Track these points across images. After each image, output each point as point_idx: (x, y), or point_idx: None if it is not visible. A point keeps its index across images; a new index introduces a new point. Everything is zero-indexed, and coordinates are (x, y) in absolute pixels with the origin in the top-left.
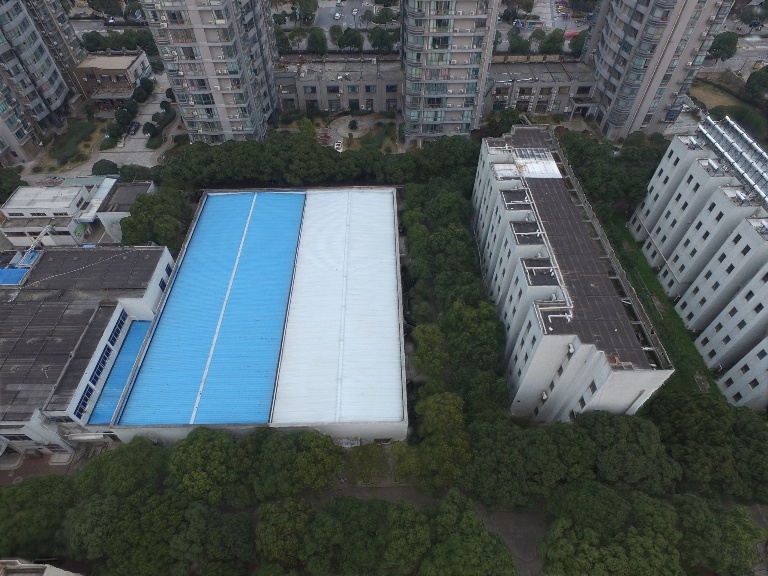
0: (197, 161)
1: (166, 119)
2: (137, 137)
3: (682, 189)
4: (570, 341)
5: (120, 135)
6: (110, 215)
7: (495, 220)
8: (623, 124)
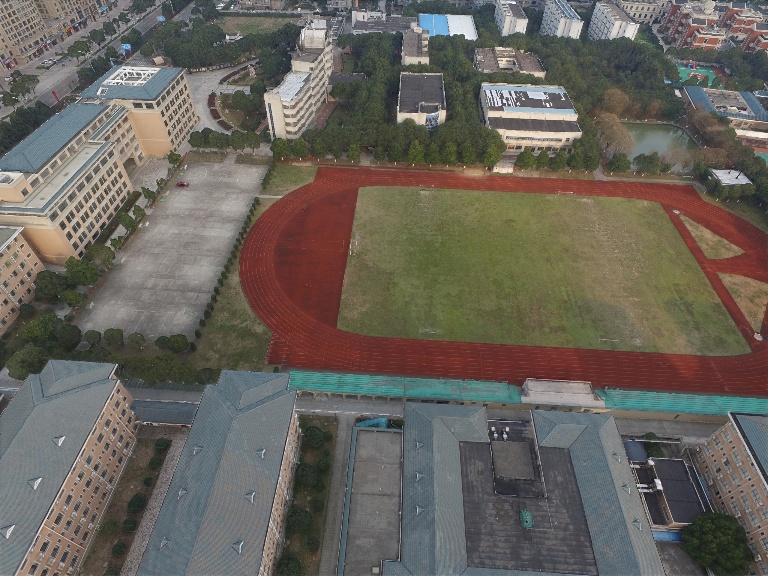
0: (417, 5)
1: (390, 5)
2: (381, 9)
3: (547, 12)
4: (511, 18)
5: (377, 8)
6: None
7: (499, 12)
8: None
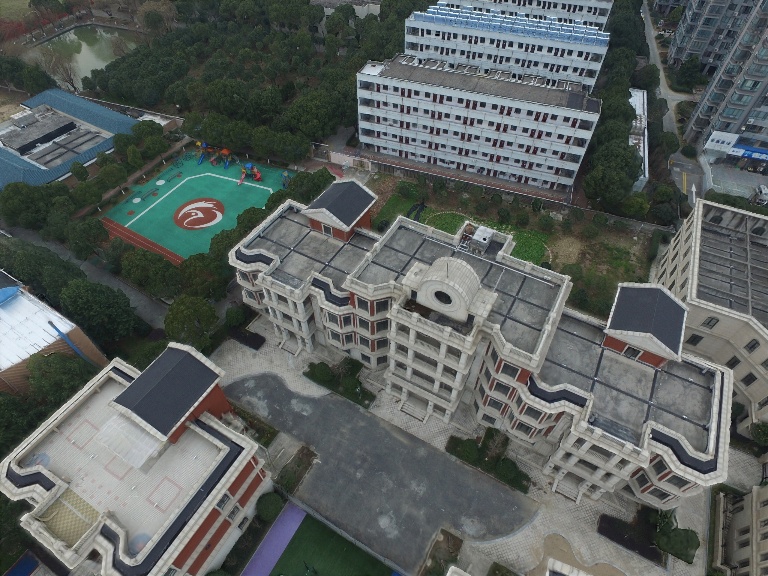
0: None
1: None
2: None
3: None
4: None
5: None
6: None
7: None
8: (694, 115)
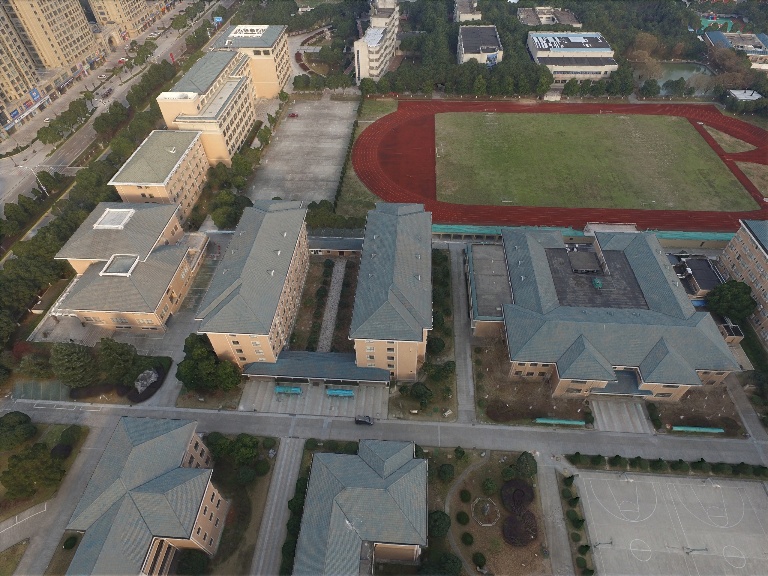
0: None
1: None
2: None
3: None
4: None
5: None
6: None
7: None
8: None
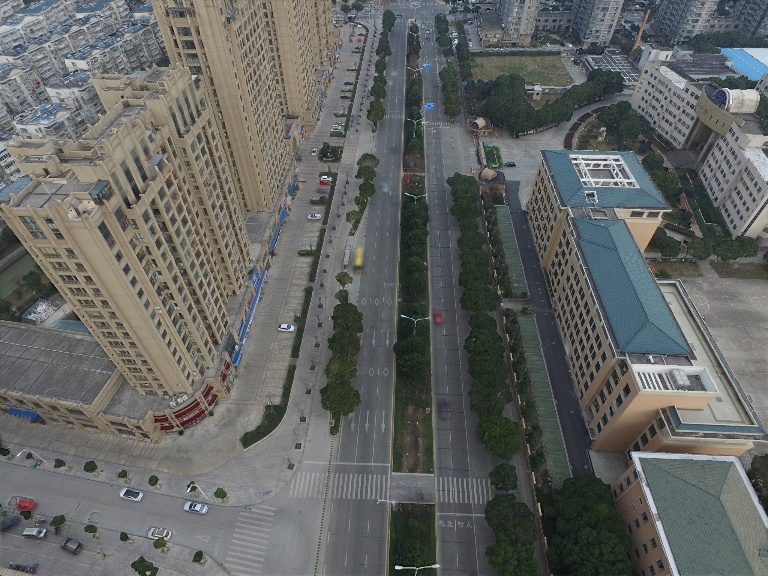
0: (706, 38)
1: None
2: None
3: None
4: None
5: None
6: (685, 52)
7: None
8: None
